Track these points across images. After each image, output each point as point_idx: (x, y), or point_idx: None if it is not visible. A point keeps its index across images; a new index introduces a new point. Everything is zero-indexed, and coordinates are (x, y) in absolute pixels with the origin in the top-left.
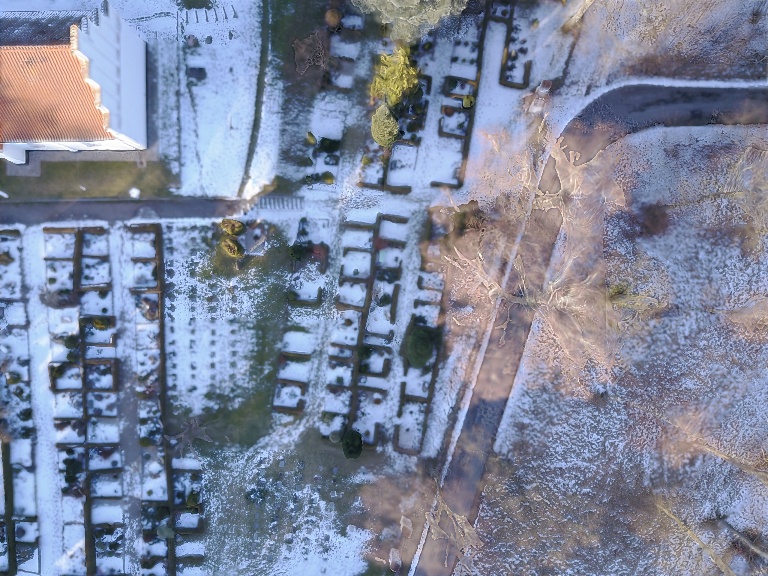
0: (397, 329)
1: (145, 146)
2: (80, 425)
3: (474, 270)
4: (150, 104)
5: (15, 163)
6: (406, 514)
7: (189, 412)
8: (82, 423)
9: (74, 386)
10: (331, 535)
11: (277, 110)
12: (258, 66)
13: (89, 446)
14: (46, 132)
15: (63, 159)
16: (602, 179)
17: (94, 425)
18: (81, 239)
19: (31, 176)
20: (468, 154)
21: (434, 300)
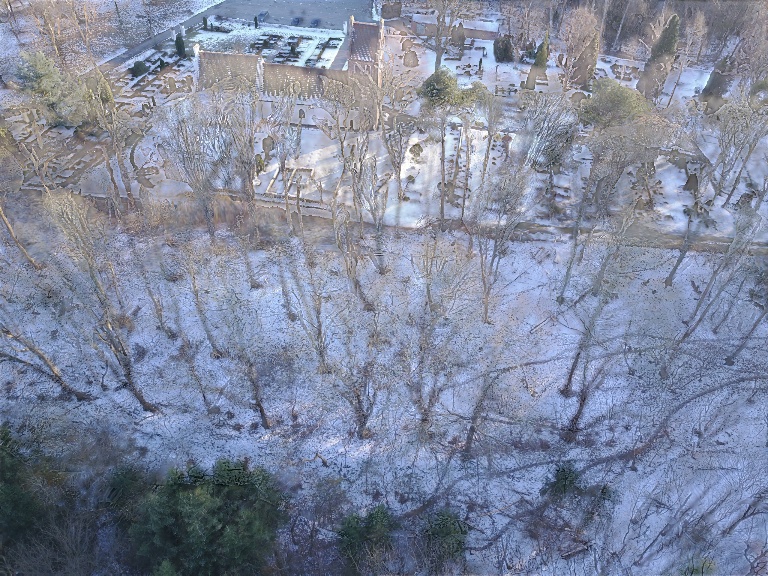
0: None
1: None
2: None
3: None
4: None
5: None
6: (173, 41)
7: None
8: None
9: None
10: None
11: None
12: None
13: (286, 56)
14: None
15: None
16: None
17: (282, 61)
18: None
19: None
20: None
21: None
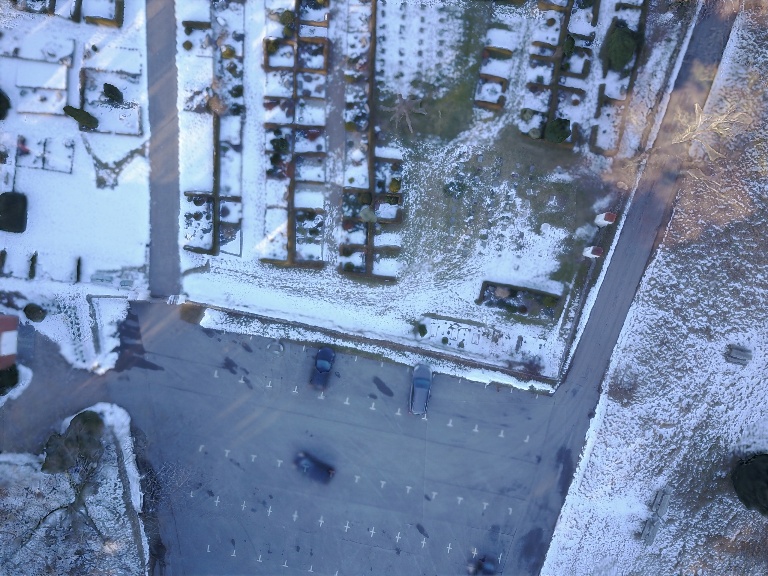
0: (598, 31)
1: None
2: (290, 104)
3: None
4: None
5: None
6: (601, 213)
7: (395, 99)
8: (291, 103)
9: (286, 64)
10: (525, 233)
11: None
12: None
13: (297, 126)
14: None
15: None
16: None
17: (302, 107)
18: None
19: None
20: None
21: (635, 4)
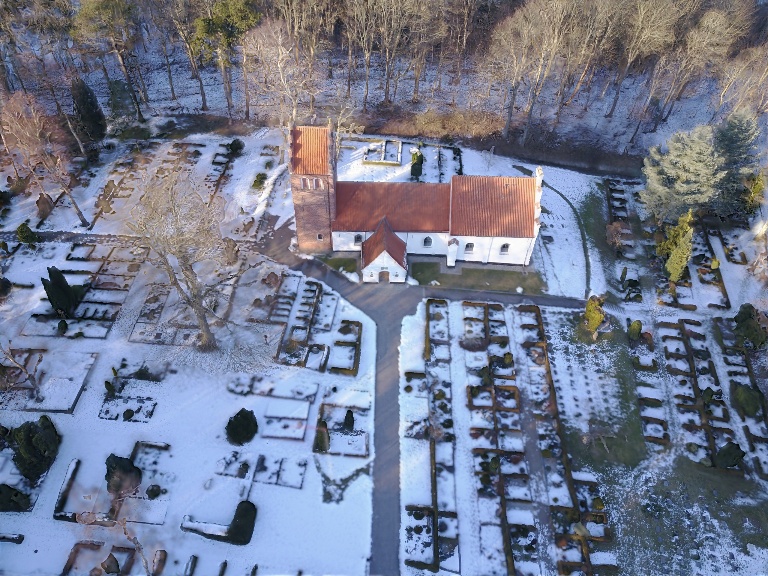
0: (722, 389)
1: (528, 263)
2: (493, 434)
3: (763, 355)
4: None
5: (448, 265)
6: None
7: None
8: (494, 433)
9: (486, 404)
10: (734, 553)
11: (598, 260)
12: (581, 240)
13: (502, 451)
14: (495, 230)
15: (476, 268)
16: None
17: (503, 437)
18: (488, 311)
19: (456, 274)
20: (726, 292)
21: (742, 372)
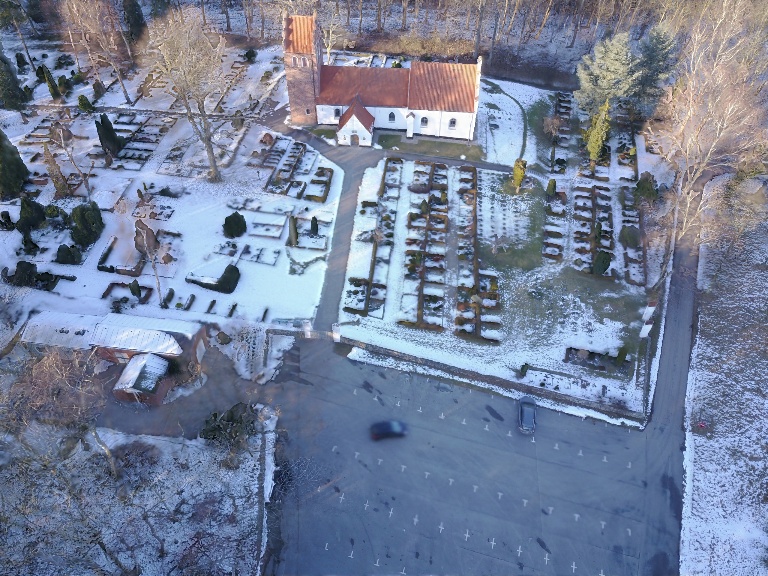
0: (615, 231)
1: (472, 138)
2: None
3: (655, 212)
4: (474, 129)
5: (407, 137)
6: None
7: None
8: (424, 243)
9: (421, 225)
10: (592, 322)
11: (534, 143)
12: (523, 130)
13: (427, 253)
14: (443, 106)
15: (430, 140)
16: (729, 72)
17: (430, 245)
18: (434, 168)
19: (413, 143)
20: (638, 171)
21: None
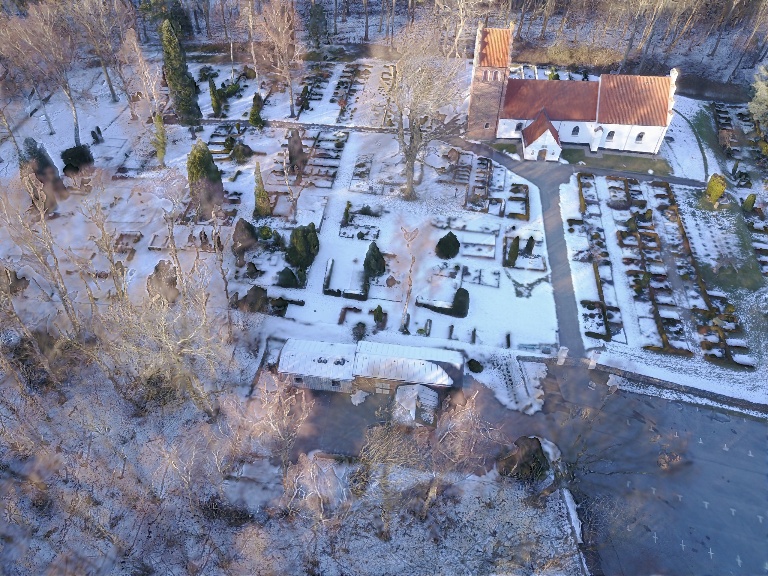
0: None
1: None
2: None
3: None
4: None
5: (592, 151)
6: None
7: (709, 266)
8: (642, 262)
9: (633, 244)
10: None
11: (713, 156)
12: (697, 142)
13: (650, 273)
14: (635, 120)
15: (613, 154)
16: None
17: (649, 265)
18: None
19: (598, 158)
20: None
21: None
